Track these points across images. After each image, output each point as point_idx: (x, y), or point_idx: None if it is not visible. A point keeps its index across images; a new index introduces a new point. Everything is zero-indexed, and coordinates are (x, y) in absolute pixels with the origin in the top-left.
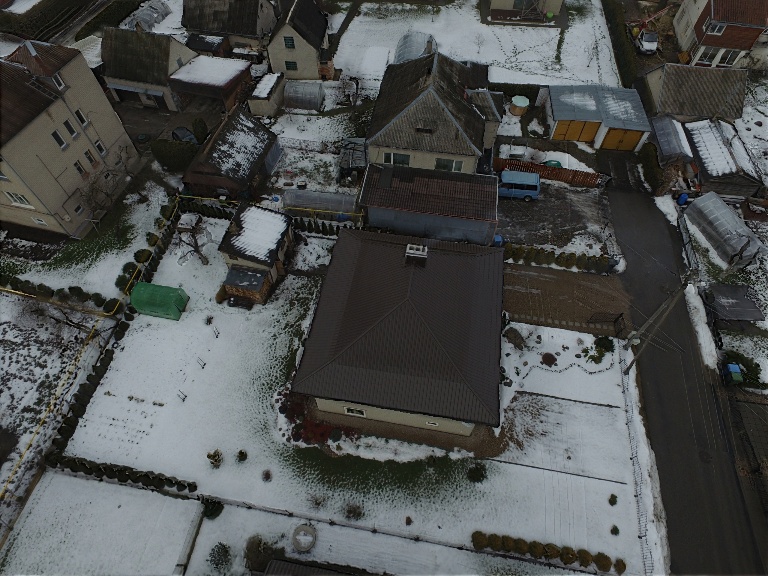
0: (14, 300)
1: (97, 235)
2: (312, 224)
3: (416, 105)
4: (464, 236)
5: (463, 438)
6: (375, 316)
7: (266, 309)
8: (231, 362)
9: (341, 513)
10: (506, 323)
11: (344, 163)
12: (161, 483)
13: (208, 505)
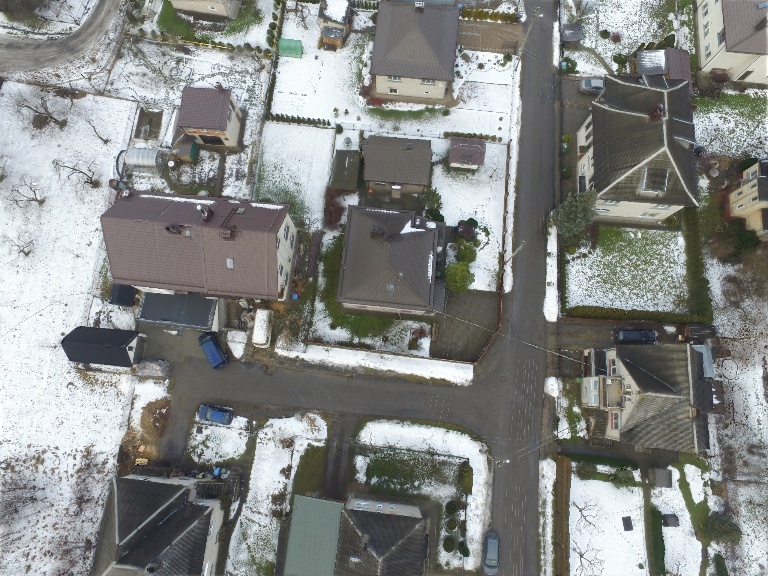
0: (215, 53)
1: (243, 16)
2: (359, 3)
3: None
4: (442, 5)
5: (440, 101)
6: (403, 36)
7: (343, 51)
8: (332, 76)
9: (391, 129)
10: (462, 50)
11: None
12: (316, 123)
13: (339, 126)
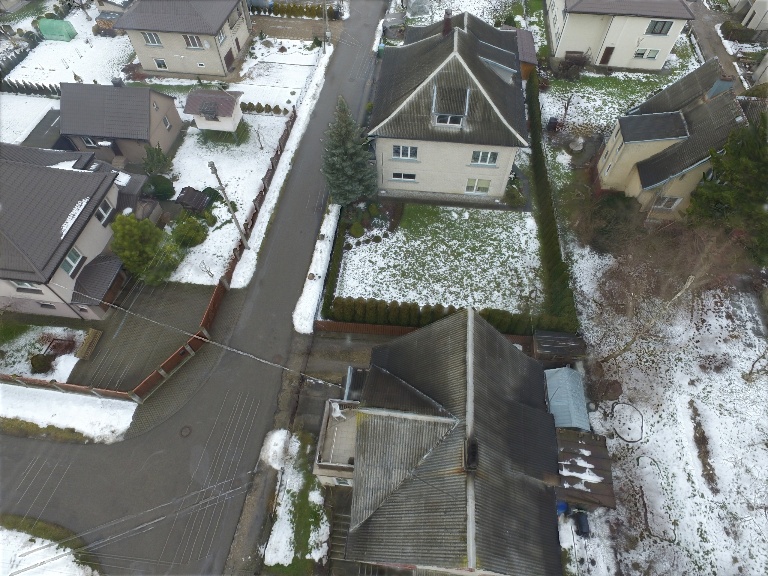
0: None
1: (23, 10)
2: None
3: None
4: (250, 1)
5: (222, 77)
6: None
7: (123, 37)
8: (97, 56)
9: None
10: (263, 37)
11: None
12: (49, 92)
13: None
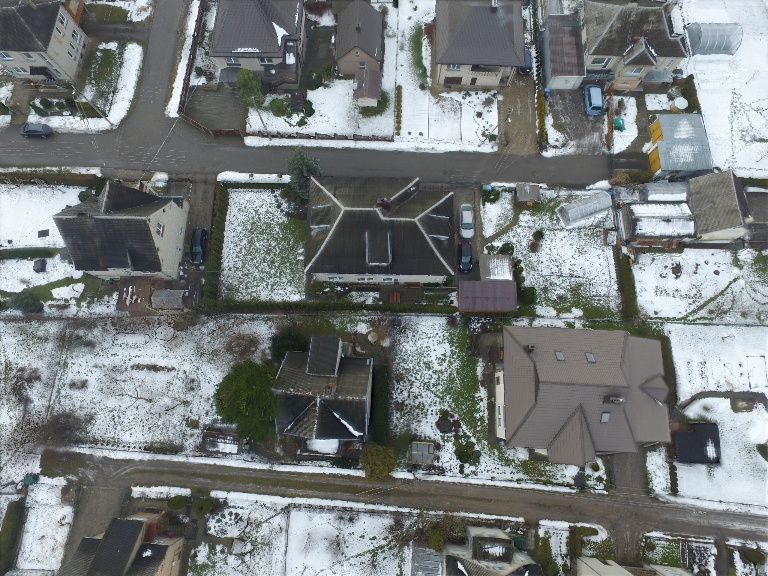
0: None
1: None
2: None
3: (611, 7)
4: None
5: (436, 82)
6: None
7: None
8: None
9: (401, 44)
10: (495, 97)
11: (580, 5)
12: None
13: None
